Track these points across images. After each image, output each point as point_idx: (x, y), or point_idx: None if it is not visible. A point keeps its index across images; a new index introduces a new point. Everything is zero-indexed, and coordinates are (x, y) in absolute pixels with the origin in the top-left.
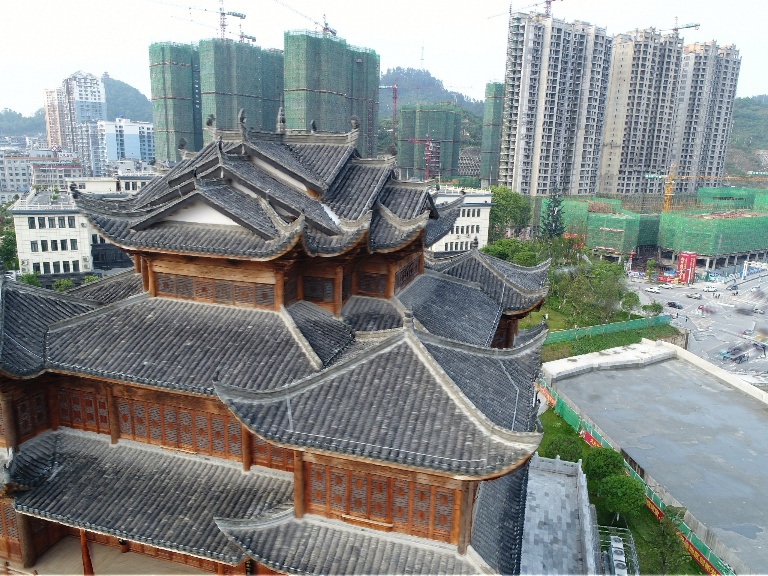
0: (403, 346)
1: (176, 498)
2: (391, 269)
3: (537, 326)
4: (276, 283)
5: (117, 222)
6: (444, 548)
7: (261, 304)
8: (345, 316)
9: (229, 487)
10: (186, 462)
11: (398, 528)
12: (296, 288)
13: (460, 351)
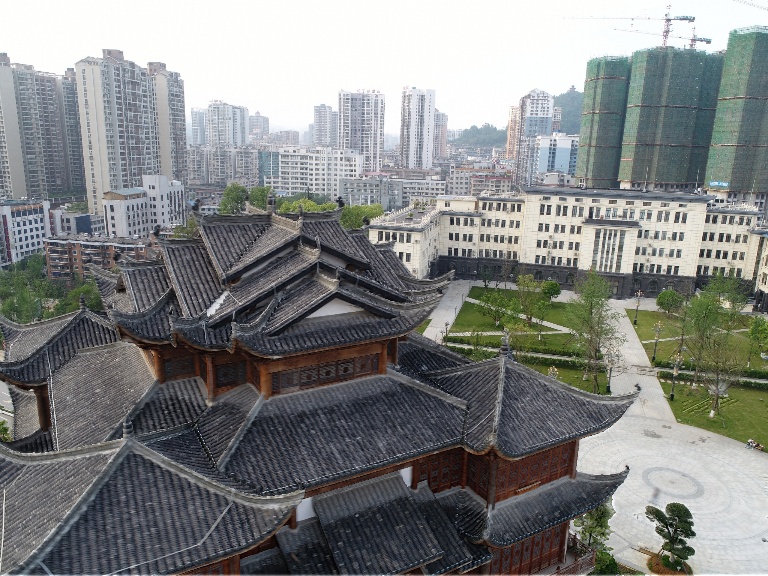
0: None
1: None
2: (260, 368)
3: (613, 476)
4: (154, 358)
5: (112, 283)
6: None
7: None
8: (216, 402)
9: None
10: None
11: None
12: (193, 365)
13: (184, 478)
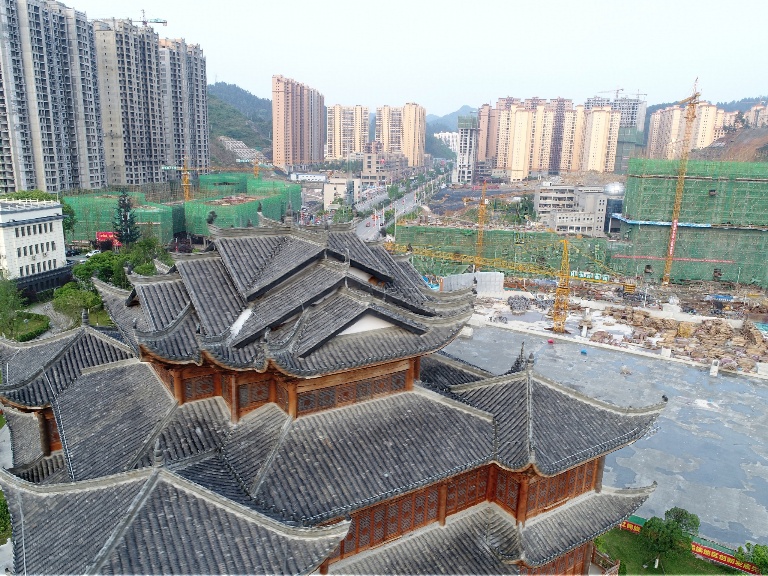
0: (536, 383)
1: (430, 574)
2: None
3: None
4: (411, 368)
5: (285, 355)
6: (590, 495)
7: (394, 389)
8: None
9: (449, 543)
10: (399, 548)
11: (569, 498)
12: None
13: None
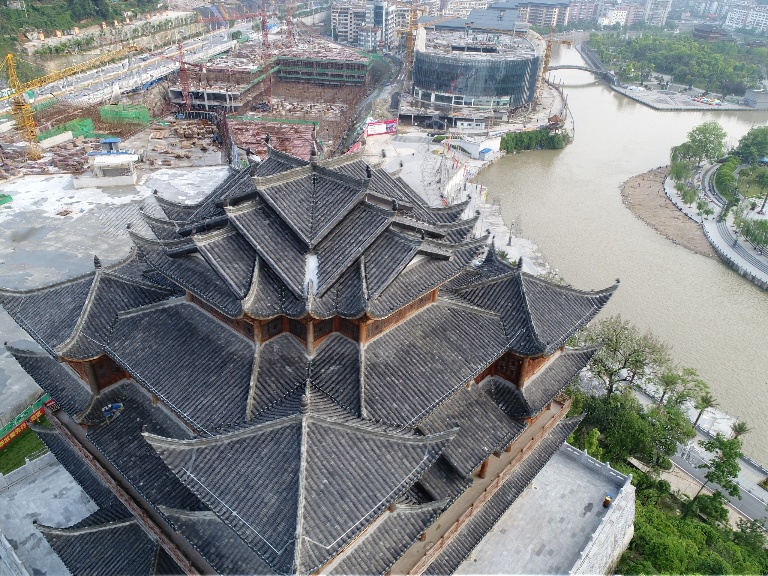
0: None
1: None
2: None
3: None
4: None
5: None
6: None
7: None
8: None
9: None
10: None
11: None
12: None
13: None
